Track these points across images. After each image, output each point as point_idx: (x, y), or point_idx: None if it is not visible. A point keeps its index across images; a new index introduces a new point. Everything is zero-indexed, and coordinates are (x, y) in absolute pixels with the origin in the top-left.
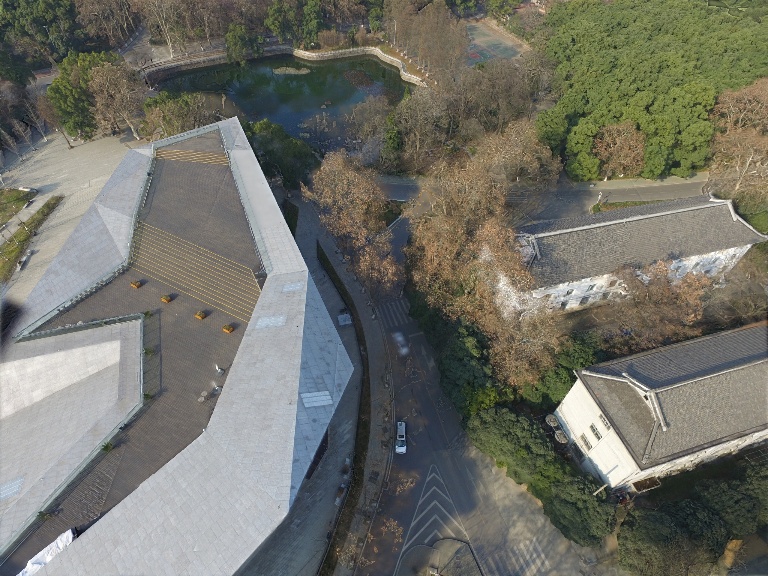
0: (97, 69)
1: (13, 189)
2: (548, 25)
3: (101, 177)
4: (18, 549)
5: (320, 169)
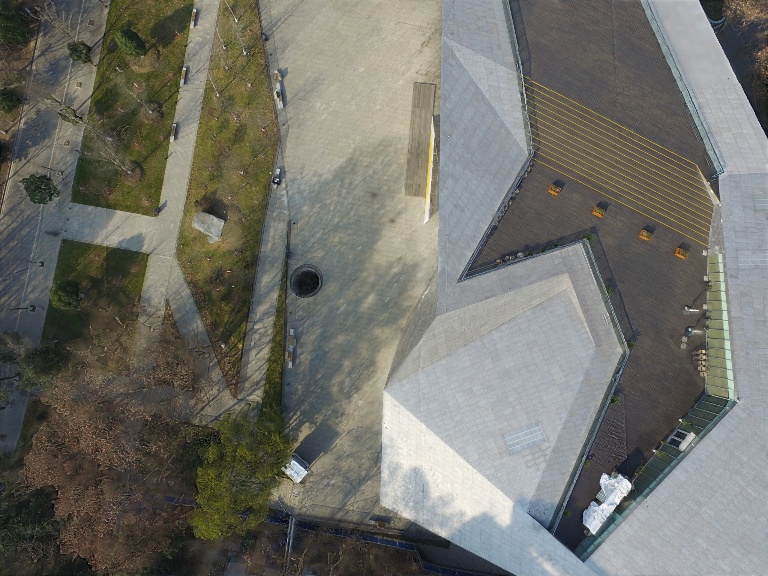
0: None
1: None
2: None
3: None
4: (574, 487)
5: None
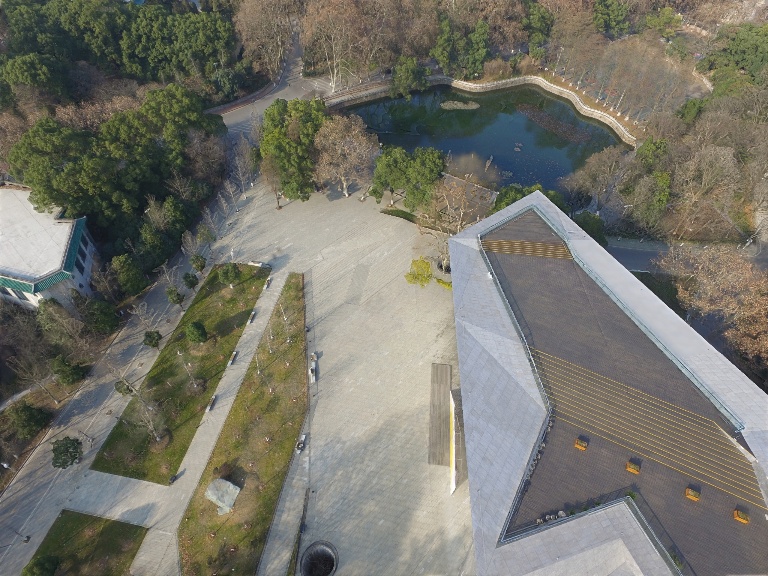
0: (334, 126)
1: (241, 264)
2: (731, 52)
3: (331, 246)
4: None
5: (696, 267)
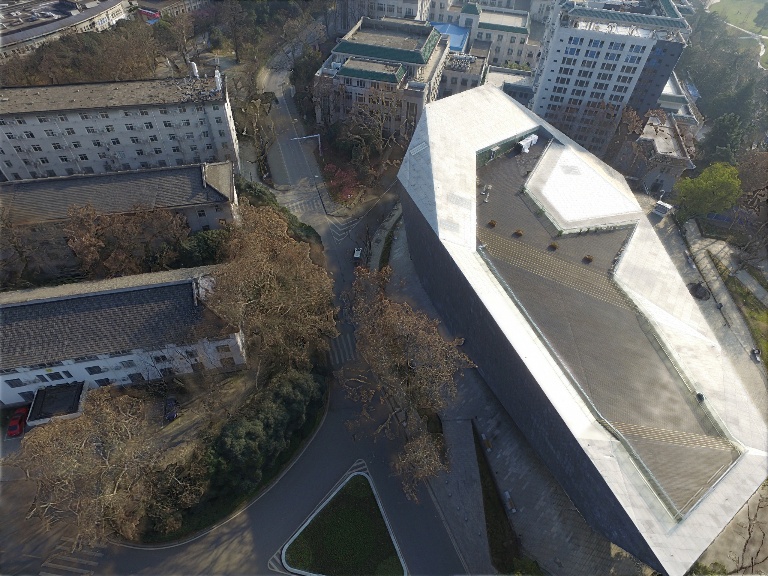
0: None
1: None
2: None
3: None
4: None
5: None
